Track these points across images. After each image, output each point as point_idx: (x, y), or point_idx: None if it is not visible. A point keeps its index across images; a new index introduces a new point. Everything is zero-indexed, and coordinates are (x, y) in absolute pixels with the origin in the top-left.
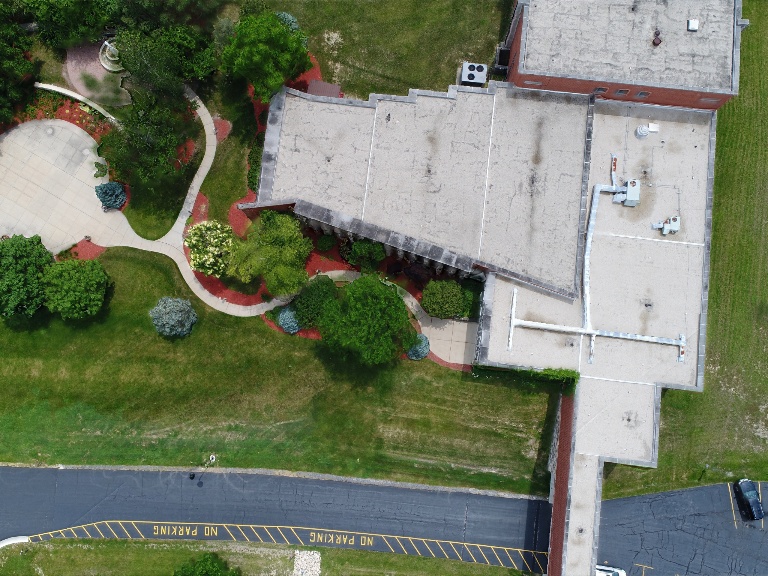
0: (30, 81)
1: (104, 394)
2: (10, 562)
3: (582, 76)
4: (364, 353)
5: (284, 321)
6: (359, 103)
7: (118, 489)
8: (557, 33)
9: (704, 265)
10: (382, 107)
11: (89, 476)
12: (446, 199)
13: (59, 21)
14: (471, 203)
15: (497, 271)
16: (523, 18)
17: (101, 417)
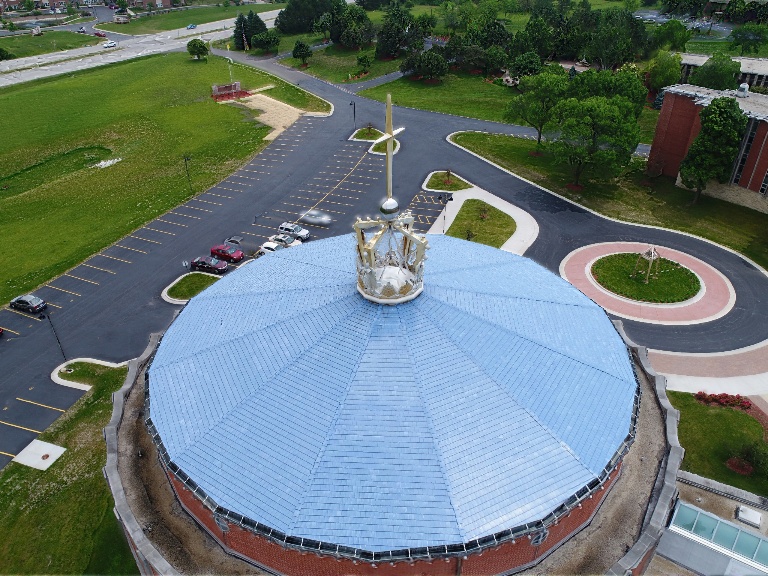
0: (542, 63)
1: None
2: (474, 134)
3: None
4: None
5: (660, 95)
6: None
7: None
8: None
9: None
10: None
11: None
12: (759, 70)
13: (571, 43)
14: None
15: None
16: None
17: None
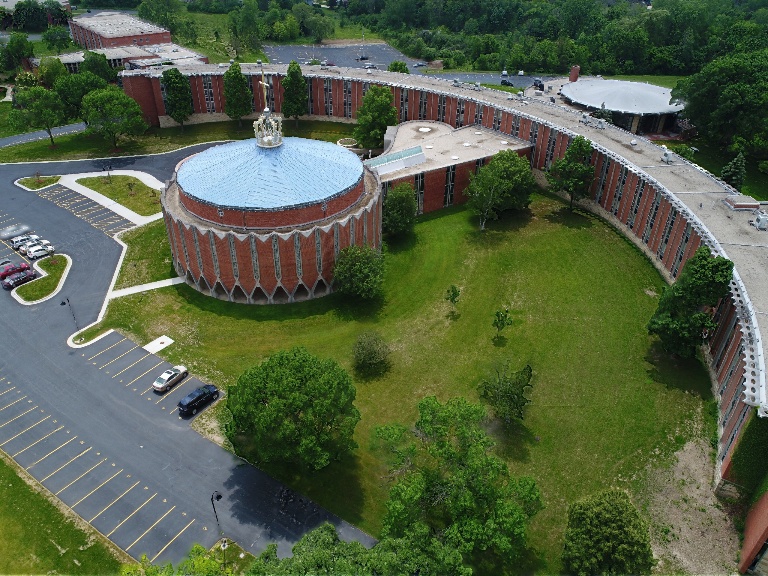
0: None
1: (0, 123)
2: None
3: (126, 36)
4: (98, 60)
5: None
6: (61, 55)
7: (23, 136)
8: (113, 36)
9: (190, 51)
10: (70, 55)
11: (7, 138)
12: None
13: None
14: (113, 56)
15: (130, 58)
16: (101, 36)
17: (2, 128)
